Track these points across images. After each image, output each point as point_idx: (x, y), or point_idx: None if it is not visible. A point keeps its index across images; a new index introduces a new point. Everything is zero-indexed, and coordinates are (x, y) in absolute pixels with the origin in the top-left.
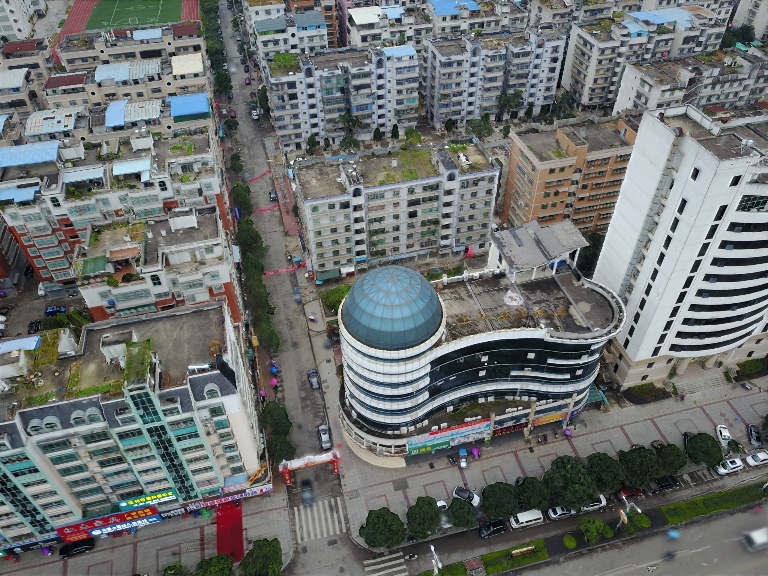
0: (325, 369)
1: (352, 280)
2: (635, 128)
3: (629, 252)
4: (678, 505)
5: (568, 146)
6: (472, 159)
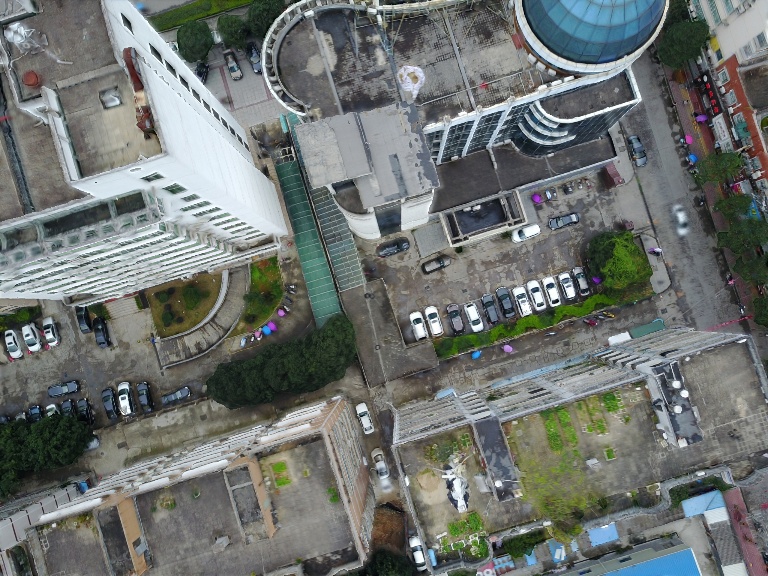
0: (625, 168)
1: (606, 338)
2: (116, 540)
3: (231, 147)
4: (237, 3)
5: (260, 484)
6: (440, 490)
